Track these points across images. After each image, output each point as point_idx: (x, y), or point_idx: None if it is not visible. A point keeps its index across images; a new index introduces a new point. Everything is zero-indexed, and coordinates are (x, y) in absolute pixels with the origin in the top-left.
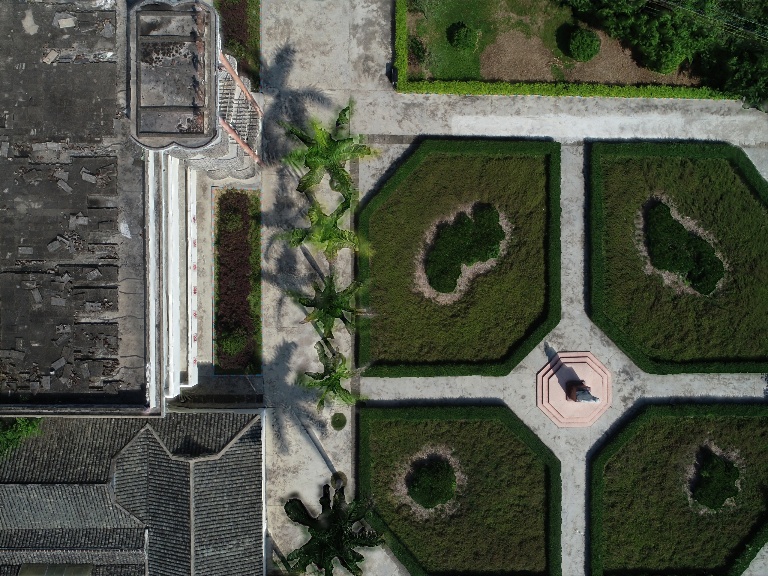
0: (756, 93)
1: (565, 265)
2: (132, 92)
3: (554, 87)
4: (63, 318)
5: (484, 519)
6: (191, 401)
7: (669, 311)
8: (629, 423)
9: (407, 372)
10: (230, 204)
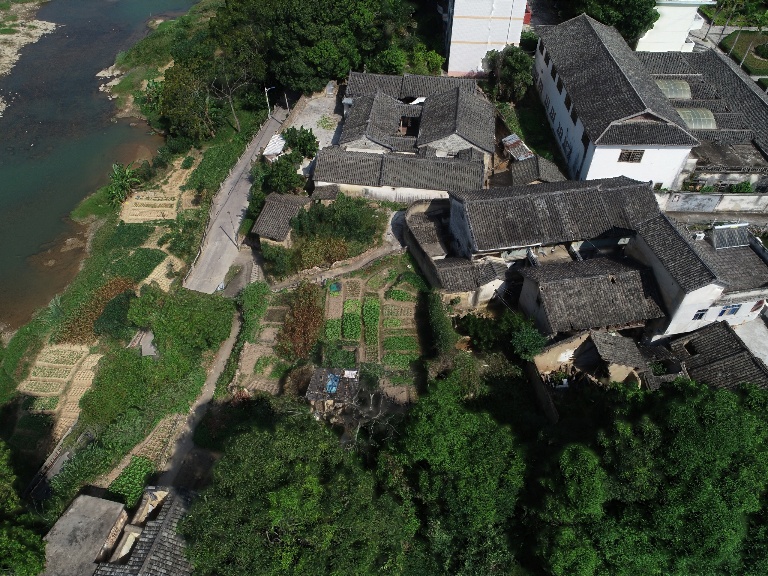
0: None
1: None
2: None
3: None
4: None
5: None
6: None
7: None
8: None
9: None
10: None
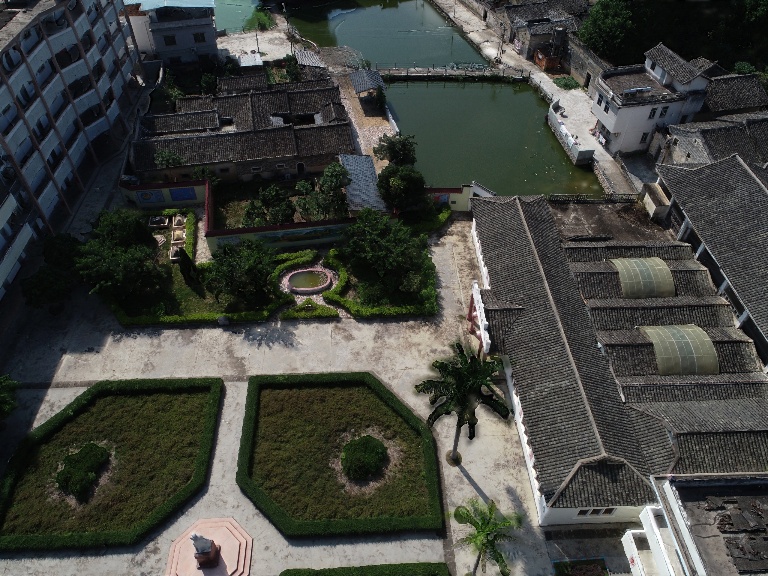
0: None
1: None
2: None
3: None
4: None
5: (315, 429)
6: (619, 530)
7: None
8: (157, 523)
9: (395, 570)
10: None
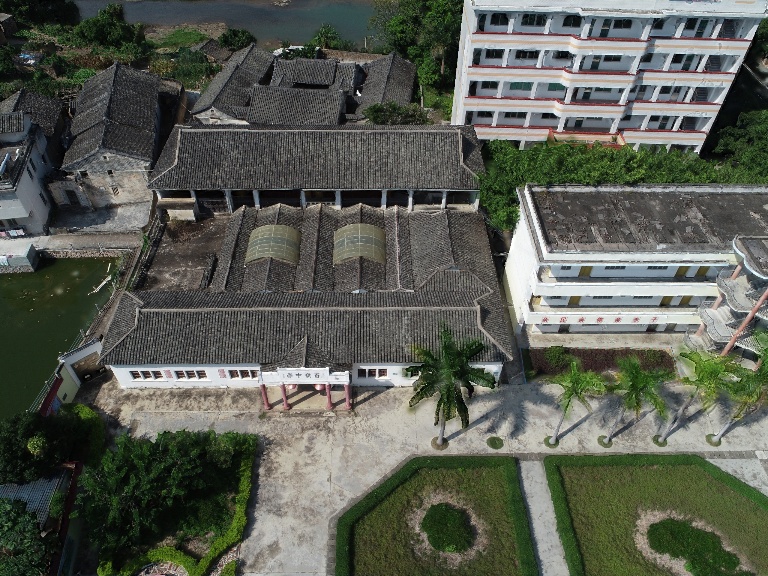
0: None
1: None
2: (767, 237)
3: None
4: (591, 219)
5: None
6: None
7: None
8: None
9: (560, 499)
10: (665, 356)
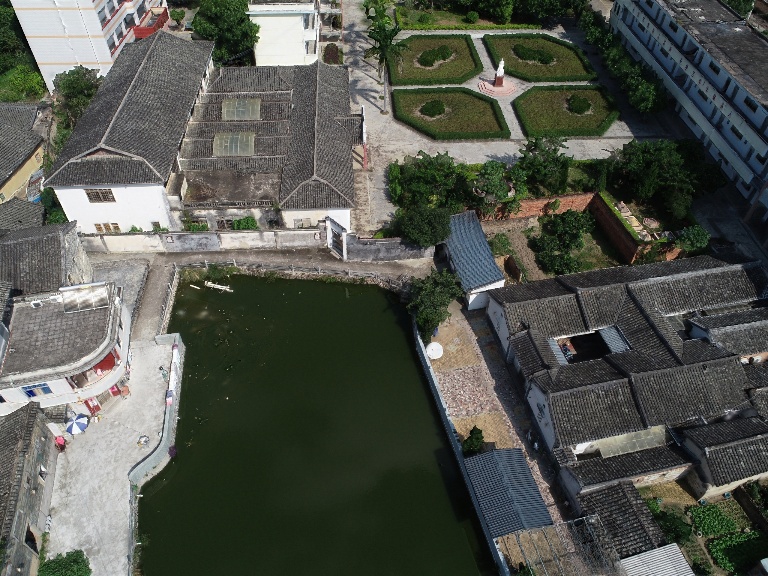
0: (540, 8)
1: (482, 61)
2: None
3: (463, 25)
4: None
5: None
6: None
7: (534, 67)
8: None
9: (414, 79)
10: None
